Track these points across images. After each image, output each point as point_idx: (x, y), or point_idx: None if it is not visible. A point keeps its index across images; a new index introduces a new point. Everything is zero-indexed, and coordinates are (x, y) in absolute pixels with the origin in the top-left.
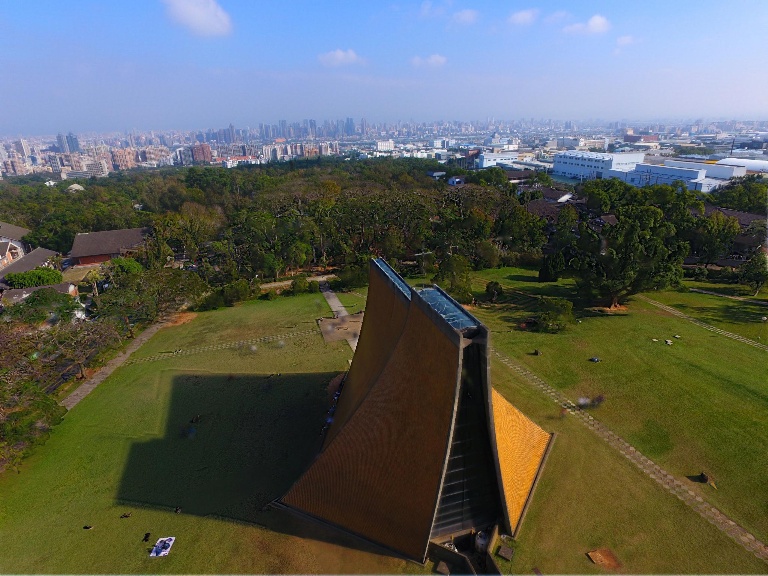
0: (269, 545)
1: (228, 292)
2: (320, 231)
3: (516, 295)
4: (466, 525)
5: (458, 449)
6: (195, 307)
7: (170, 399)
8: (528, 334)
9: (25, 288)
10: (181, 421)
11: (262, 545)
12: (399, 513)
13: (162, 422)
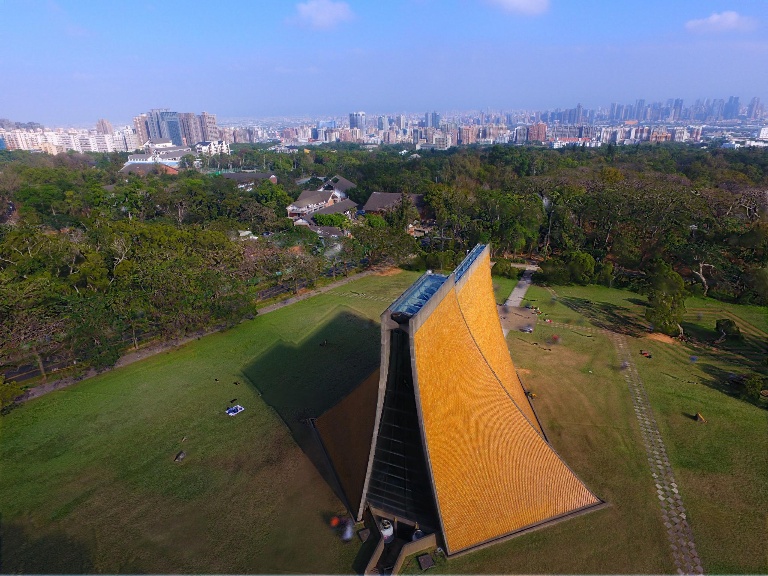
0: (282, 444)
1: (430, 258)
2: (544, 218)
3: (764, 347)
4: (410, 516)
5: (398, 433)
6: (396, 264)
7: (325, 325)
8: (717, 394)
9: (321, 226)
10: (316, 342)
11: (278, 441)
12: (355, 468)
13: (306, 338)
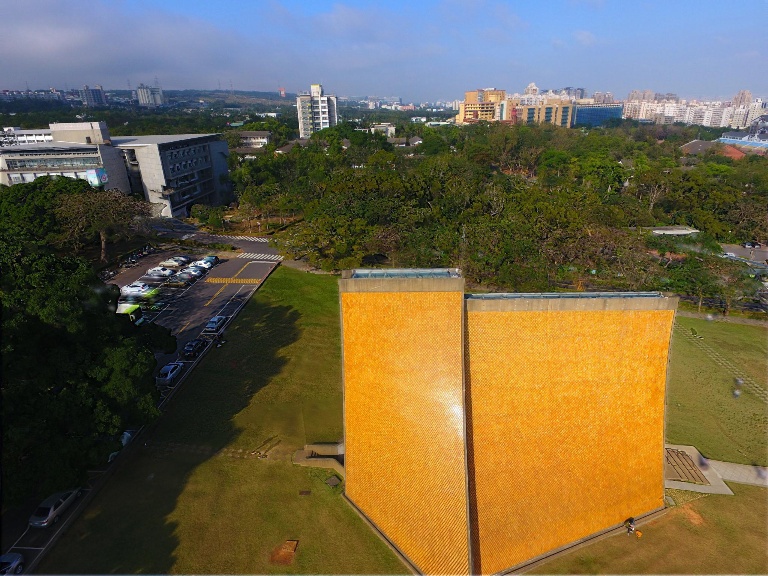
0: None
1: None
2: None
3: None
4: None
5: None
6: None
7: None
8: None
9: None
10: None
11: None
12: None
13: None
